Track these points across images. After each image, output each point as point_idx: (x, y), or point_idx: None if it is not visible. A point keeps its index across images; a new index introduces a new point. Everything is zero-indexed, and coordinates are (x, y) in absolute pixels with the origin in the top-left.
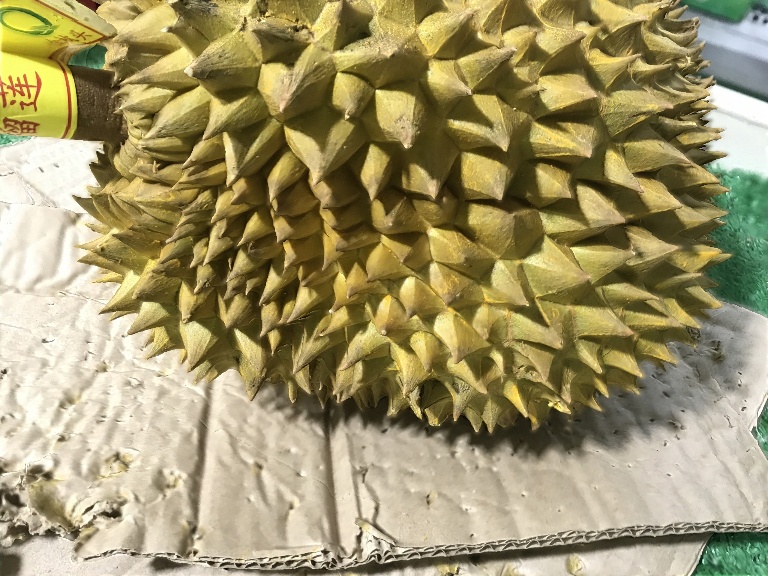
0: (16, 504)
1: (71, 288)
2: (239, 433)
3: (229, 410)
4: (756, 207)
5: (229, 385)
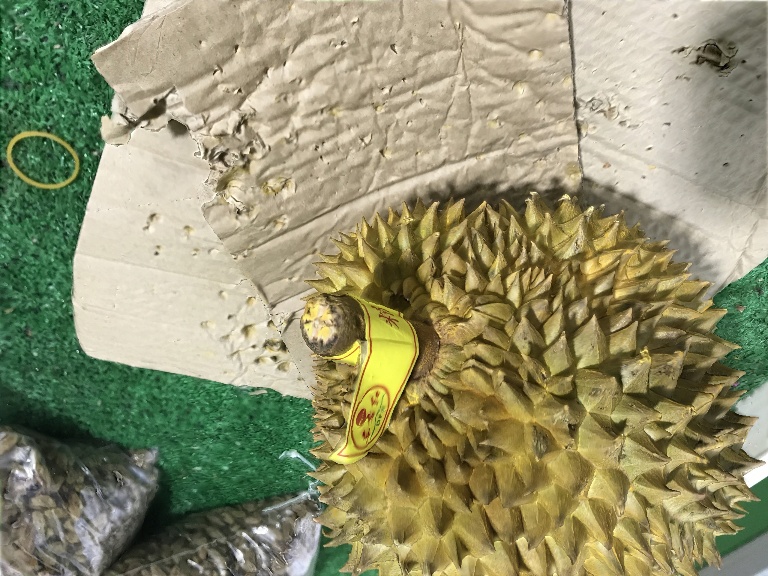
0: None
1: (468, 31)
2: (338, 230)
3: (358, 215)
4: None
5: None
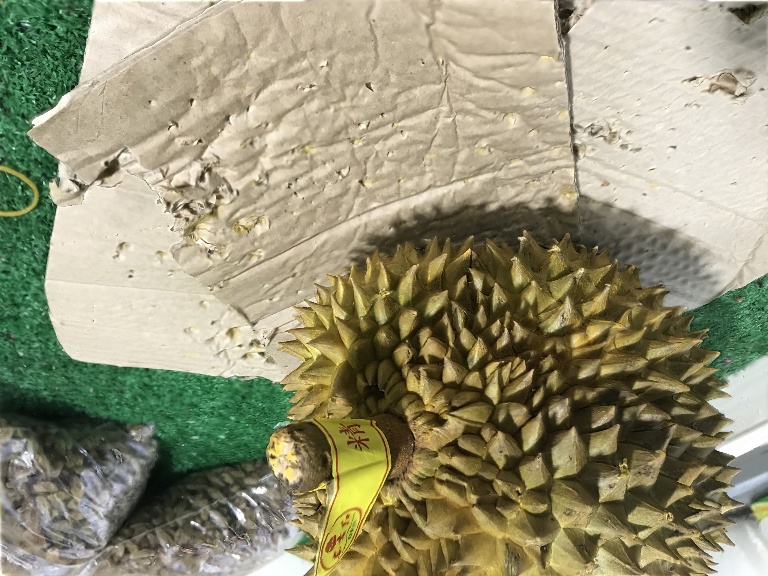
0: None
1: (453, 68)
2: None
3: (338, 240)
4: None
5: (365, 227)
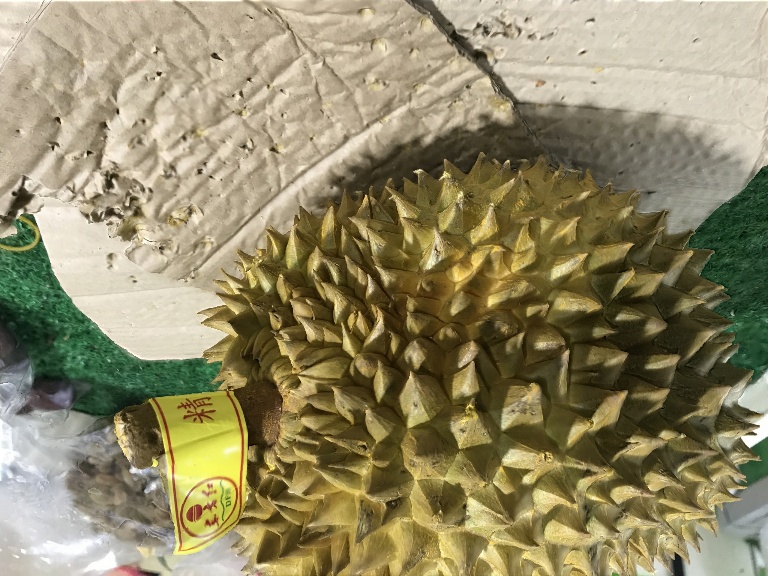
0: (110, 213)
1: (282, 13)
2: None
3: (284, 211)
4: (756, 331)
5: (304, 192)
